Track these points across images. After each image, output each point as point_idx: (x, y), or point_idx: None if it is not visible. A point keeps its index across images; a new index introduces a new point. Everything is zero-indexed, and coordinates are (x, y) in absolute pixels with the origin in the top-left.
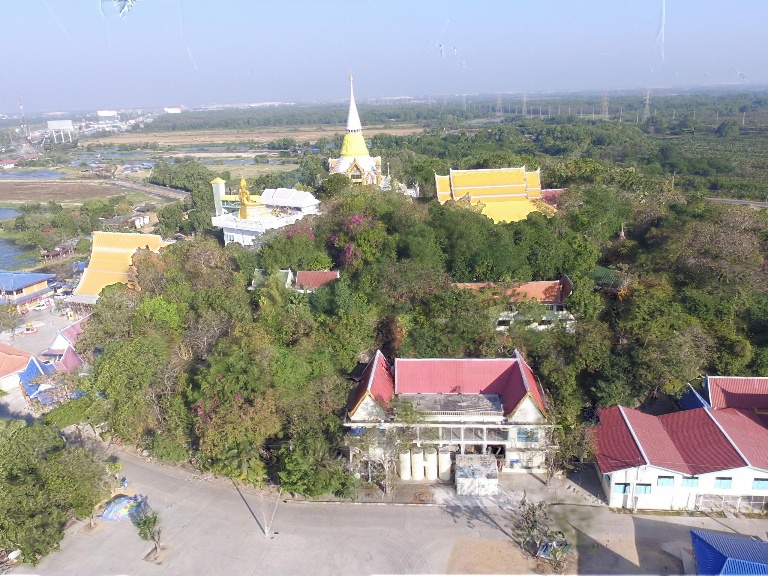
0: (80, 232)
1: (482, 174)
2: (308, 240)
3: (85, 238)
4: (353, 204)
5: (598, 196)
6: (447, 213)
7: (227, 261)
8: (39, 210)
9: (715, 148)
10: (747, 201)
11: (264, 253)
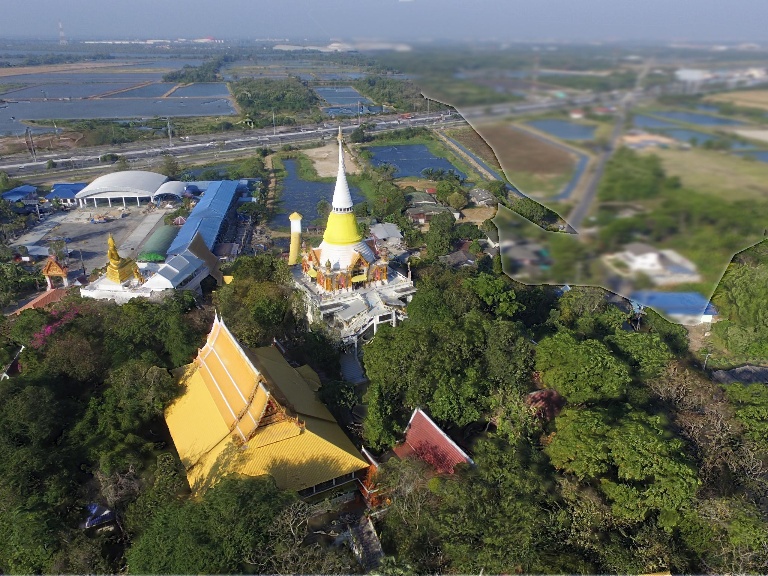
0: (373, 213)
1: (234, 349)
2: (42, 327)
3: (363, 220)
4: (117, 309)
5: (194, 507)
6: None
7: (51, 310)
8: (441, 176)
9: None
10: None
11: None
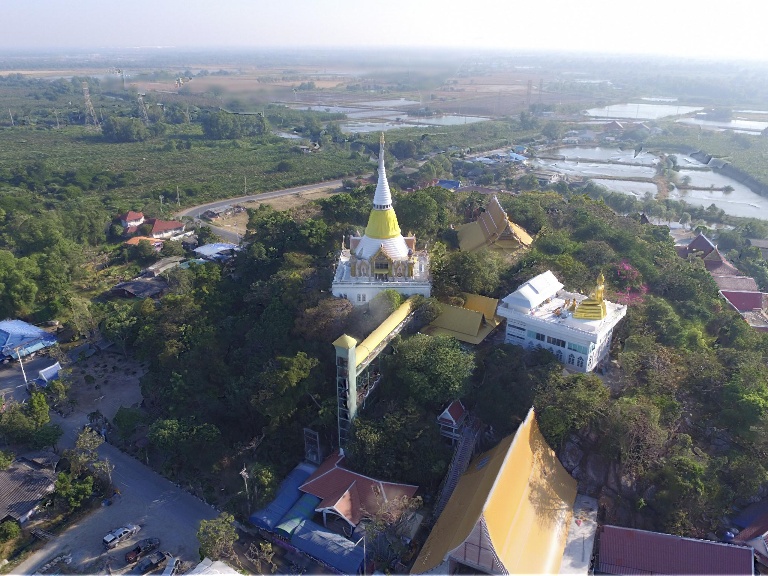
0: None
1: None
2: None
3: None
4: None
5: (528, 205)
6: (626, 237)
7: None
8: None
9: (7, 157)
10: (236, 198)
11: (675, 320)
